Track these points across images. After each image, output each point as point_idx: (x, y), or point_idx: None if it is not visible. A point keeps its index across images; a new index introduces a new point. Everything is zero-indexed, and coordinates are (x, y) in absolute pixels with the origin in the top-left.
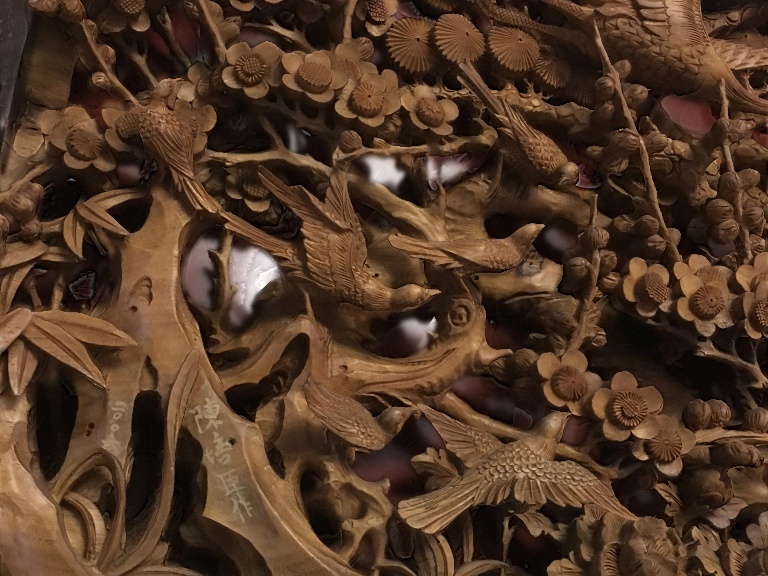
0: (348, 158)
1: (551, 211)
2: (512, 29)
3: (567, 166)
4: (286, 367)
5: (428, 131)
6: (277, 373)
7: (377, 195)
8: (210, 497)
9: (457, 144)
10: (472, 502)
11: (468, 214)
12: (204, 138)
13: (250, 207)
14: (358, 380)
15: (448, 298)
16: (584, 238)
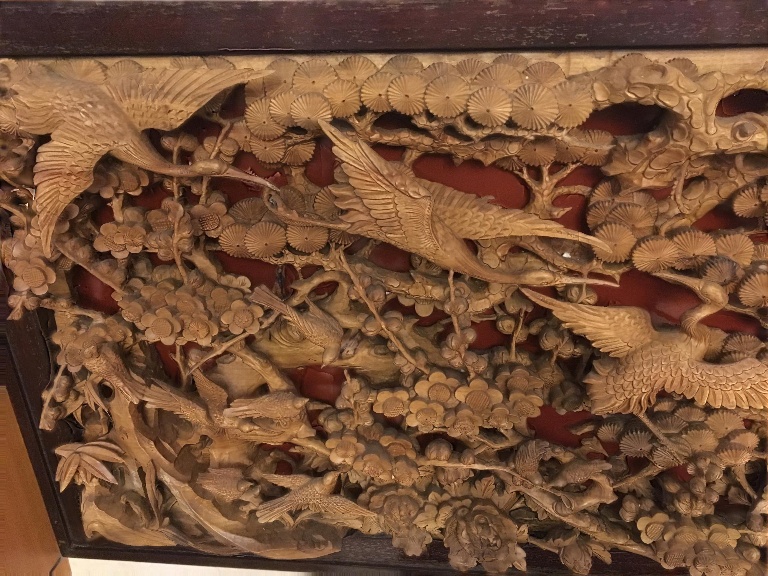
0: None
1: None
2: (301, 228)
3: (324, 358)
4: None
5: None
6: None
7: (232, 352)
8: (179, 503)
9: (274, 317)
10: (291, 508)
11: (295, 342)
12: (130, 339)
13: (177, 343)
14: None
15: None
16: None
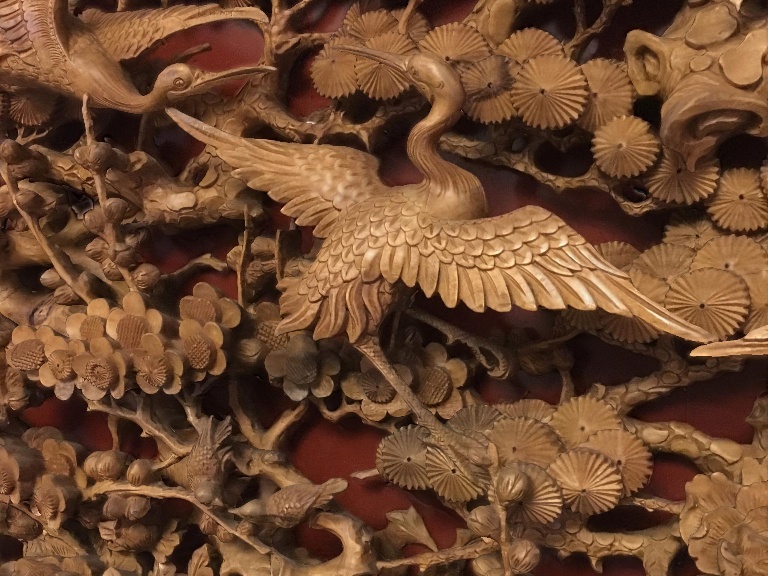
0: None
1: None
2: None
3: None
4: None
5: None
6: None
7: None
8: None
9: None
10: None
11: None
12: None
13: None
14: None
15: None
16: None
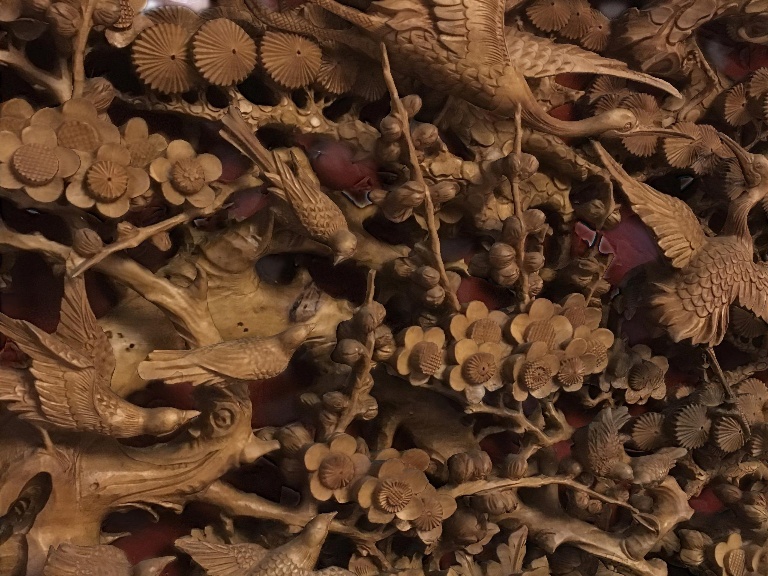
0: (85, 270)
1: (328, 250)
2: (289, 36)
3: (344, 243)
4: (27, 494)
5: (185, 203)
6: (17, 500)
7: (126, 275)
8: None
9: (221, 198)
10: None
11: (235, 271)
12: None
13: None
14: (112, 495)
15: (210, 400)
16: (359, 321)
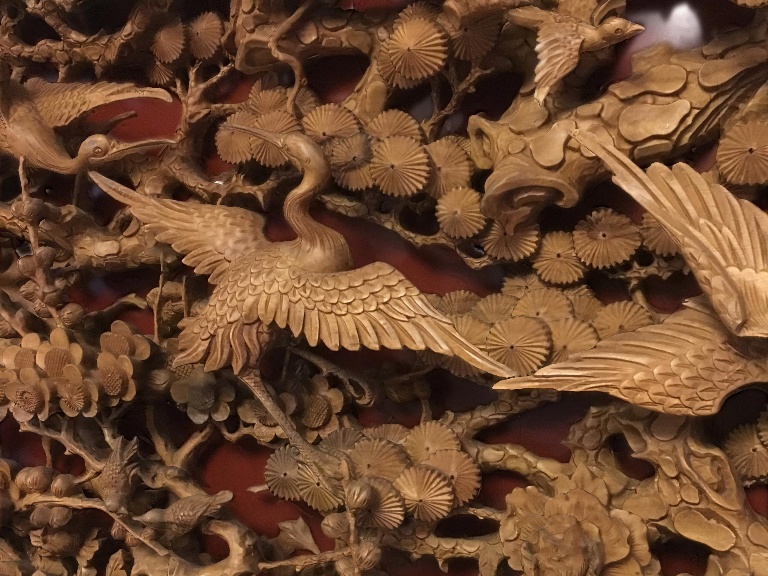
0: None
1: None
2: None
3: None
4: None
5: None
6: None
7: None
8: None
9: None
10: None
11: None
12: None
13: None
14: None
15: None
16: None
